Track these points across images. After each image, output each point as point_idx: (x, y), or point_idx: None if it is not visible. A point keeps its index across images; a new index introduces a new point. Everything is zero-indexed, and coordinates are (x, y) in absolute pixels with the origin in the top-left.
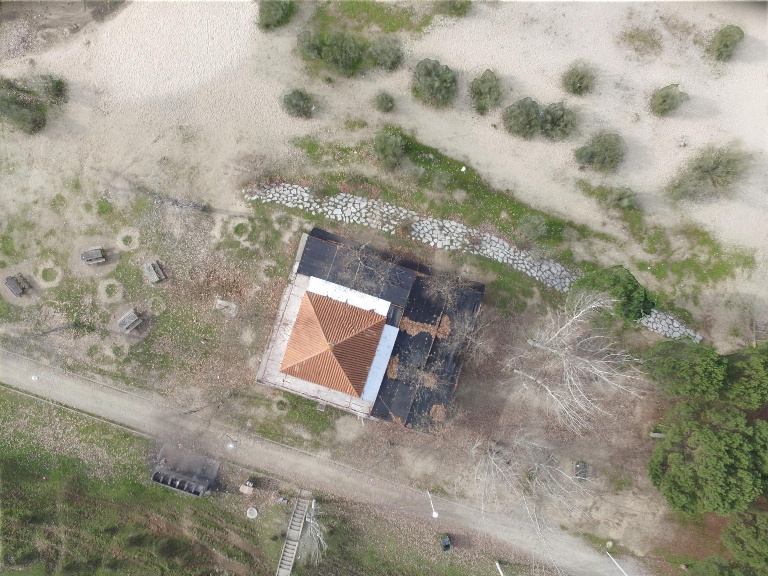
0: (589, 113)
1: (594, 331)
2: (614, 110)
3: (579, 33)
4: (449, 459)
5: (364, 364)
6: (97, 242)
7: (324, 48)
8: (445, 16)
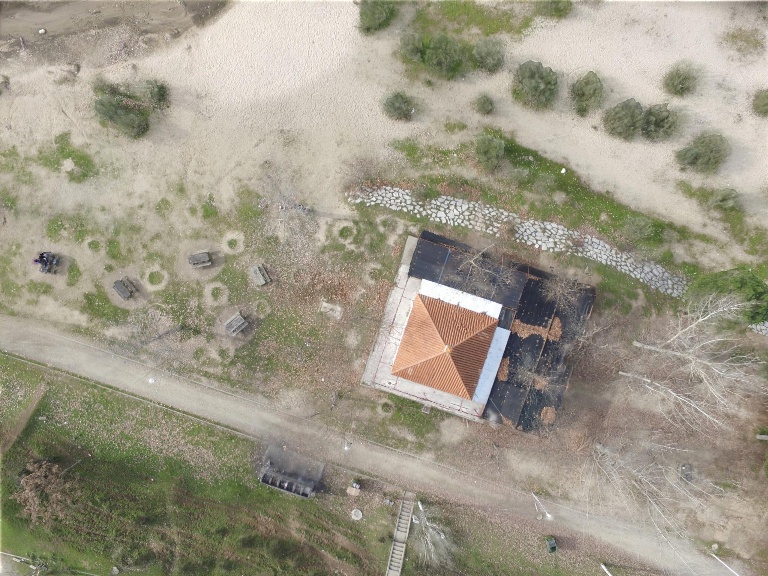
0: (690, 114)
1: (717, 333)
2: (716, 111)
3: (681, 34)
4: (553, 461)
5: (477, 366)
6: (202, 246)
7: (428, 51)
8: (546, 18)
